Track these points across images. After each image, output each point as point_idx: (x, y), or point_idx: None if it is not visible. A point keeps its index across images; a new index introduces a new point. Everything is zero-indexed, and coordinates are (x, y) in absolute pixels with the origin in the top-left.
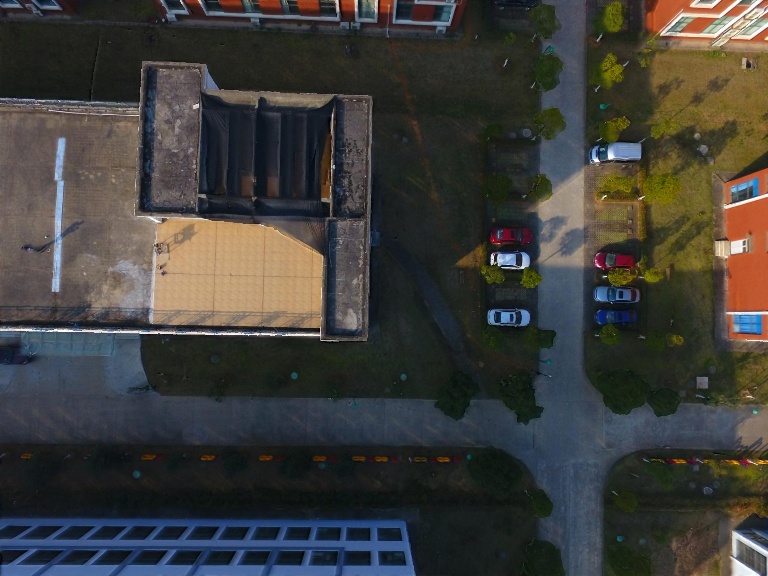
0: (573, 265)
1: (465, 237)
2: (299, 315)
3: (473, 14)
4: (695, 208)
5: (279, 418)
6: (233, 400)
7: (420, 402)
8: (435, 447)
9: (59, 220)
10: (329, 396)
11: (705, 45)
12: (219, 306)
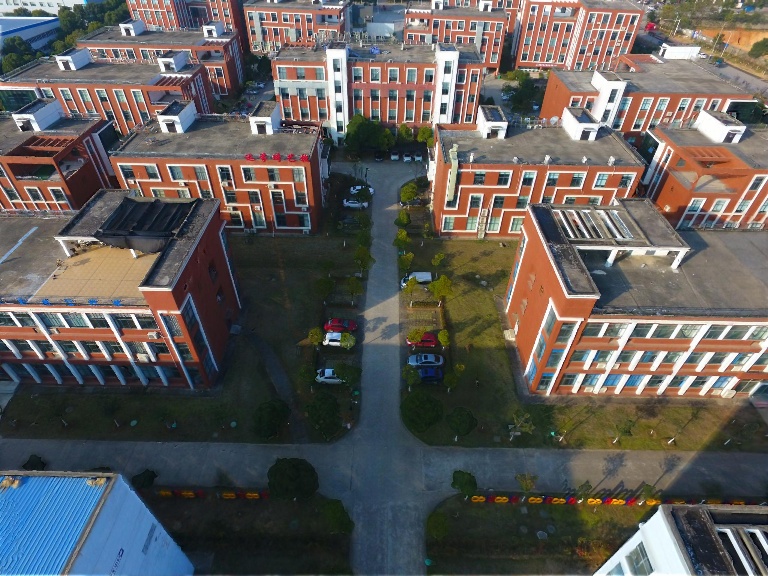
0: (391, 345)
1: (306, 328)
2: (136, 298)
3: (328, 228)
4: (484, 313)
5: (103, 459)
6: (67, 443)
7: (244, 446)
8: (249, 488)
9: (6, 257)
10: (159, 440)
11: (474, 238)
12: (82, 294)
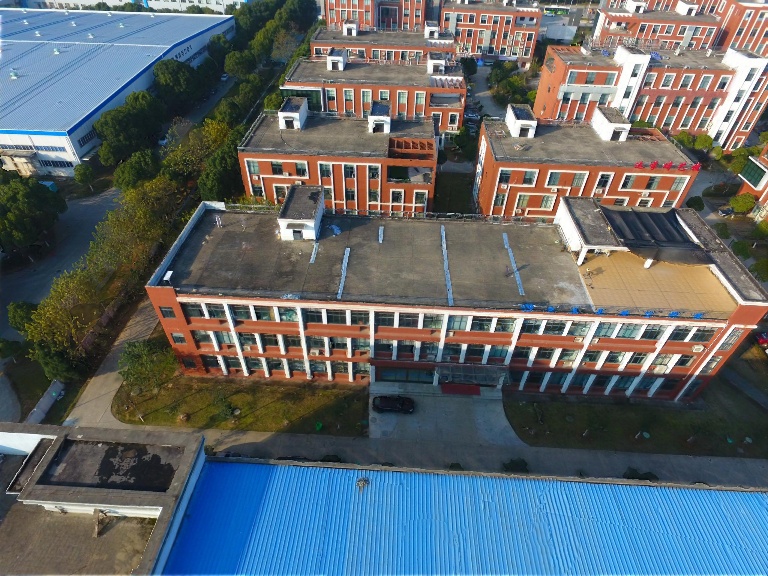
0: None
1: None
2: (699, 311)
3: None
4: None
5: (649, 471)
6: (598, 453)
7: None
8: None
9: (514, 263)
10: (687, 454)
11: None
12: (639, 305)
